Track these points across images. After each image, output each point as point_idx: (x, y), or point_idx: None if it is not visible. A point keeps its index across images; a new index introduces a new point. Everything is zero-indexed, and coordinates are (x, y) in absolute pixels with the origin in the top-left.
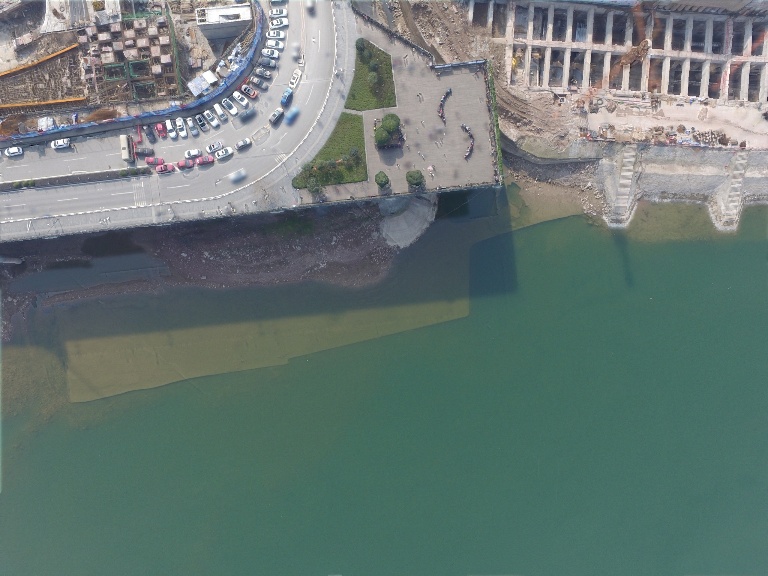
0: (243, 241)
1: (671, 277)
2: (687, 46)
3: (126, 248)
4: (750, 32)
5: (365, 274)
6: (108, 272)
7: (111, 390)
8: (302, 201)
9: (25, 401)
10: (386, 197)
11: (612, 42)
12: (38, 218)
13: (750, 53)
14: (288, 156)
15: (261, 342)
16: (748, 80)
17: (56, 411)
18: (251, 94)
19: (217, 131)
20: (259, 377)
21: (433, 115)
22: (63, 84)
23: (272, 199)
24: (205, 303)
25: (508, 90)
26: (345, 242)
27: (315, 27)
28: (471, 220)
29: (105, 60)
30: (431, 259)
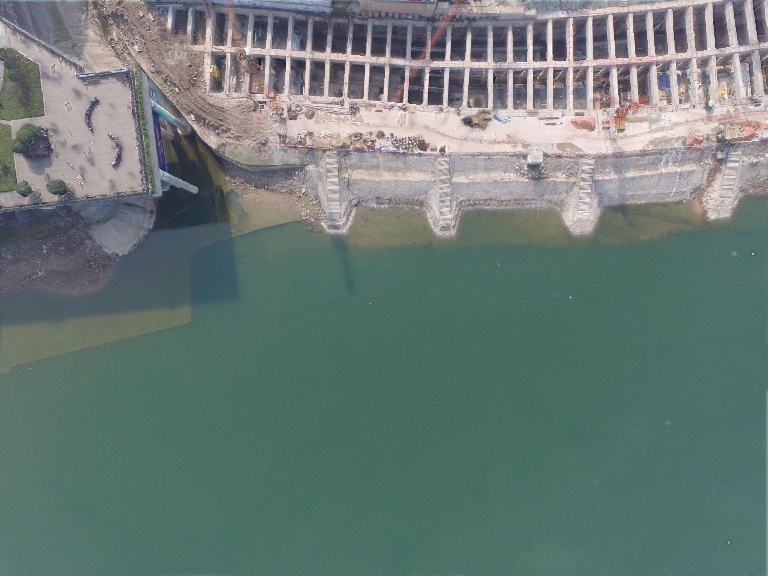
0: None
1: (391, 283)
2: (386, 52)
3: None
4: (449, 38)
5: (84, 282)
6: None
7: None
8: None
9: None
10: (36, 206)
11: (332, 48)
12: None
13: (449, 59)
14: None
15: None
16: (447, 85)
17: None
18: None
19: None
20: None
21: (81, 124)
22: None
23: None
24: None
25: (203, 97)
26: (57, 250)
27: None
28: (191, 227)
29: None
30: (152, 266)
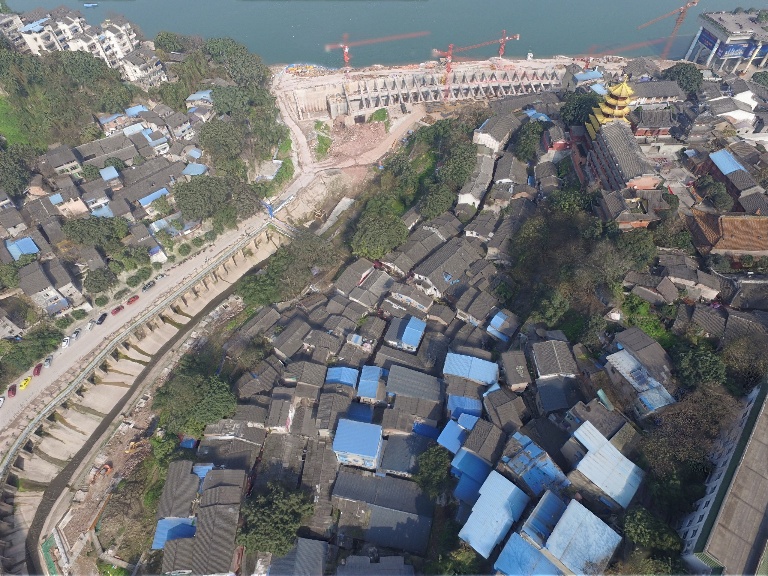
0: None
1: None
2: None
3: None
4: None
5: None
6: None
7: None
8: None
9: None
10: None
11: None
12: None
13: None
14: None
15: None
16: None
17: None
18: None
19: None
20: None
21: (743, 25)
22: None
23: None
24: None
25: None
26: None
27: None
28: (678, 57)
29: None
30: None
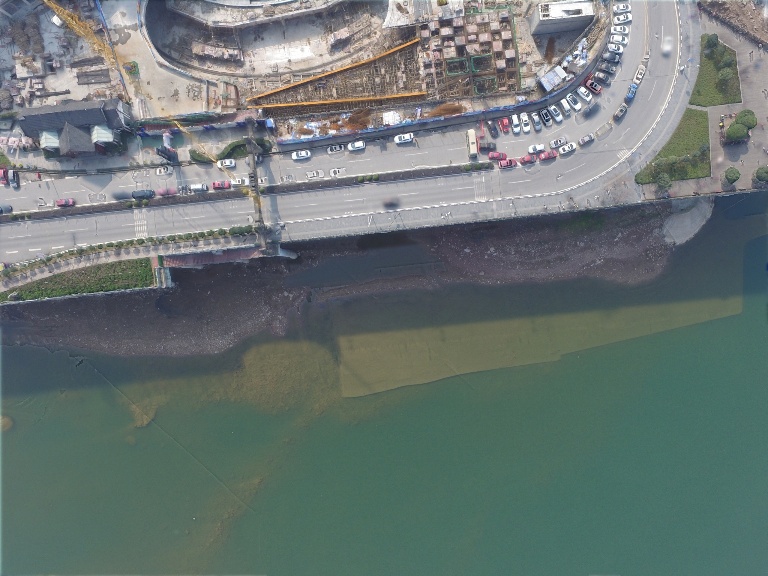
0: (533, 237)
1: None
2: None
3: (401, 243)
4: None
5: (640, 271)
6: (383, 267)
7: (383, 385)
8: (645, 197)
9: (297, 396)
10: (730, 193)
11: None
12: (379, 212)
13: None
14: (630, 152)
15: (534, 338)
16: None
17: (328, 406)
18: (598, 89)
19: (559, 126)
20: (530, 373)
21: None
22: (398, 79)
23: (614, 195)
24: (478, 299)
25: None
26: (628, 238)
27: (658, 23)
28: (746, 217)
29: (447, 55)
30: (705, 256)
